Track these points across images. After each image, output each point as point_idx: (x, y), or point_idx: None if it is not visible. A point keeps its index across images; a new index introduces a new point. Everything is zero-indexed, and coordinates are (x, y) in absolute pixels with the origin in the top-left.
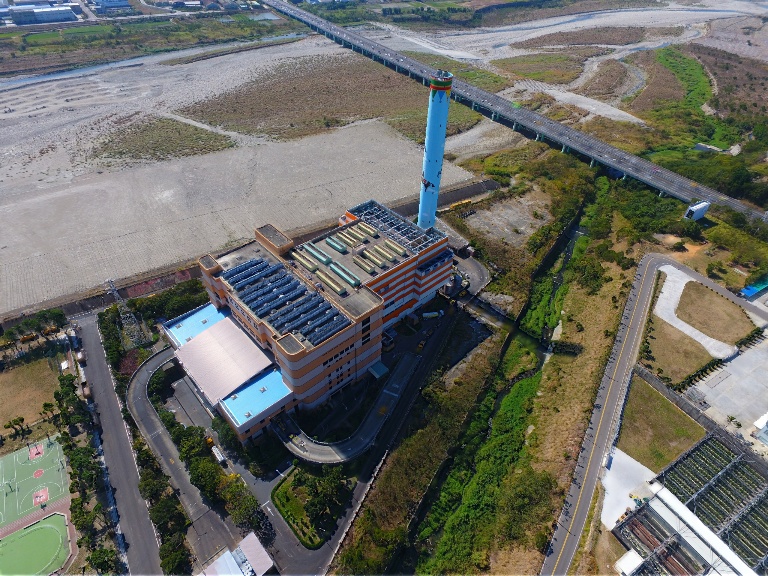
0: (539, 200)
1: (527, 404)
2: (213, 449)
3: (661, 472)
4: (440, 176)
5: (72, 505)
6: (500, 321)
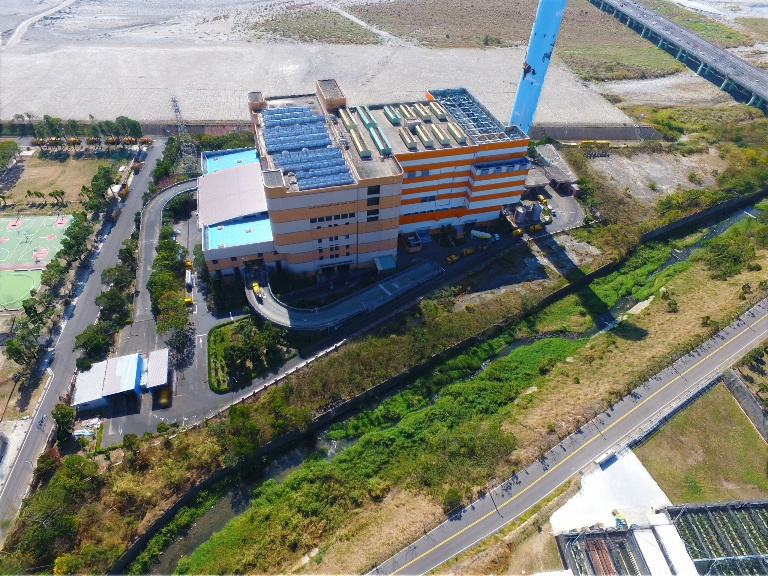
0: (709, 164)
1: (544, 363)
2: (186, 271)
3: (680, 505)
4: (547, 61)
5: (48, 264)
6: (566, 269)
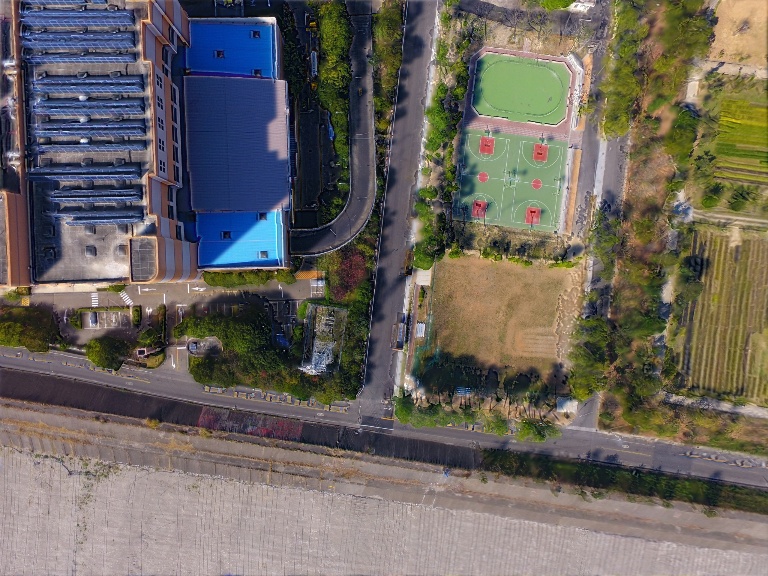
0: None
1: None
2: (316, 71)
3: None
4: None
5: (464, 89)
6: None
